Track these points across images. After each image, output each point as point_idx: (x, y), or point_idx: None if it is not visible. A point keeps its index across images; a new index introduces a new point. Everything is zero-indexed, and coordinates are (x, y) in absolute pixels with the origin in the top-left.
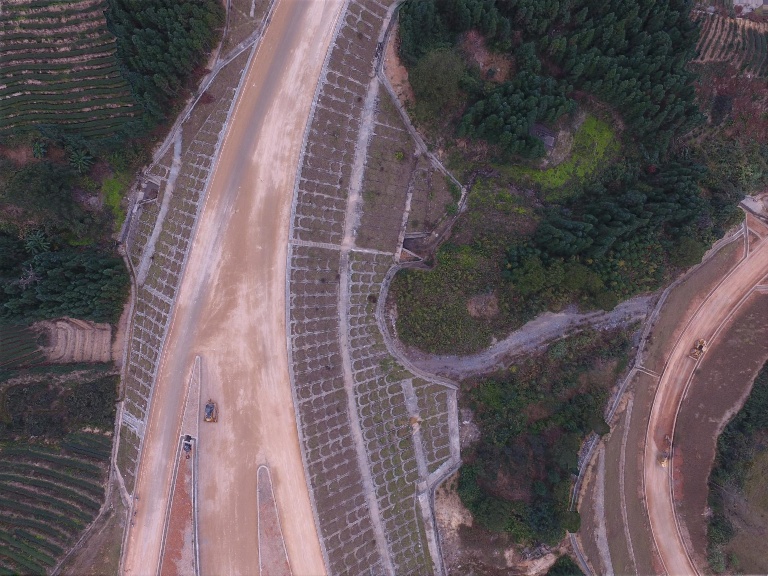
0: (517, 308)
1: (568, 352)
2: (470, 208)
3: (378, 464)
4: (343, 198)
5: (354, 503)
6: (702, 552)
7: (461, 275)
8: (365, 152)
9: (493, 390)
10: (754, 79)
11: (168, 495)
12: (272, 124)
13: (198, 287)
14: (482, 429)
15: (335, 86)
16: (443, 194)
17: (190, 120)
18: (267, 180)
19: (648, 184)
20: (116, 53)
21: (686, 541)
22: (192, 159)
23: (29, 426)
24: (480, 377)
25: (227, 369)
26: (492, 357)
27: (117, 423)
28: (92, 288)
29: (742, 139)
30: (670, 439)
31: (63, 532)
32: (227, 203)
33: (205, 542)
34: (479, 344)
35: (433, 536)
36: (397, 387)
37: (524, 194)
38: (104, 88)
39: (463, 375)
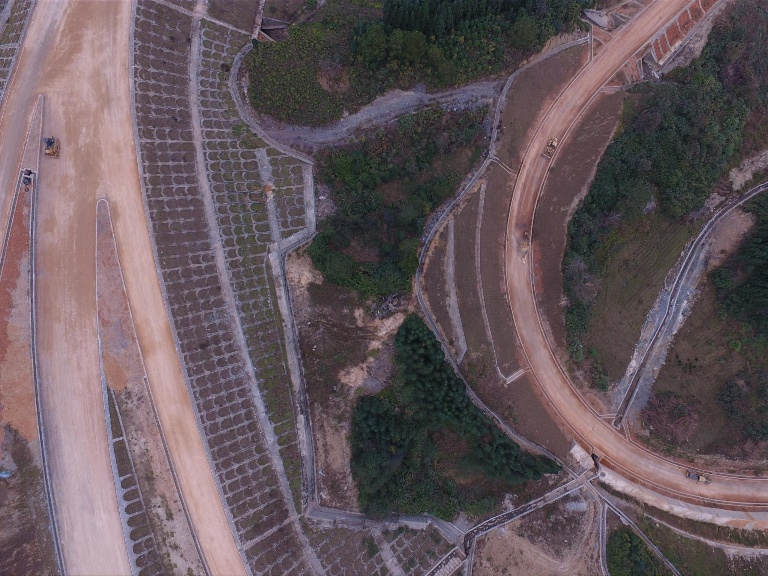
0: (365, 81)
1: (417, 127)
2: None
3: (226, 217)
4: None
5: (198, 247)
6: (563, 344)
7: (309, 43)
8: None
9: (345, 161)
10: None
11: (6, 227)
12: None
13: (44, 32)
14: (338, 204)
15: None
16: None
17: None
18: None
19: None
20: None
21: (548, 336)
22: None
23: None
24: (333, 149)
25: (70, 108)
26: (344, 130)
27: None
28: None
29: None
30: (529, 236)
31: None
32: None
33: (42, 273)
34: (329, 114)
35: (283, 293)
36: (251, 155)
37: None
38: None
39: (316, 146)
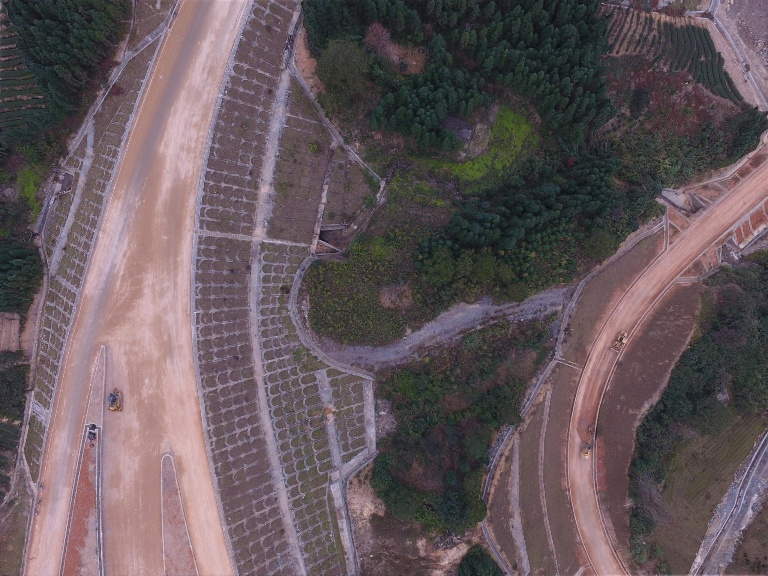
0: (430, 299)
1: (482, 343)
2: (389, 200)
3: (288, 454)
4: (254, 189)
5: (262, 492)
6: (625, 543)
7: (372, 266)
8: (276, 144)
9: (407, 381)
10: (671, 73)
11: (73, 483)
12: (179, 115)
13: (104, 277)
14: (398, 420)
15: (243, 78)
16: (361, 186)
17: (101, 112)
18: (173, 171)
19: (563, 177)
20: (18, 44)
21: (610, 532)
22: (103, 150)
23: None
24: (395, 368)
25: (132, 358)
26: (406, 348)
27: (27, 412)
28: None
29: (662, 133)
30: (593, 431)
31: None
32: (133, 194)
33: (109, 530)
34: (392, 335)
35: (345, 526)
36: (311, 377)
37: (443, 187)
38: (13, 80)
39: (377, 366)
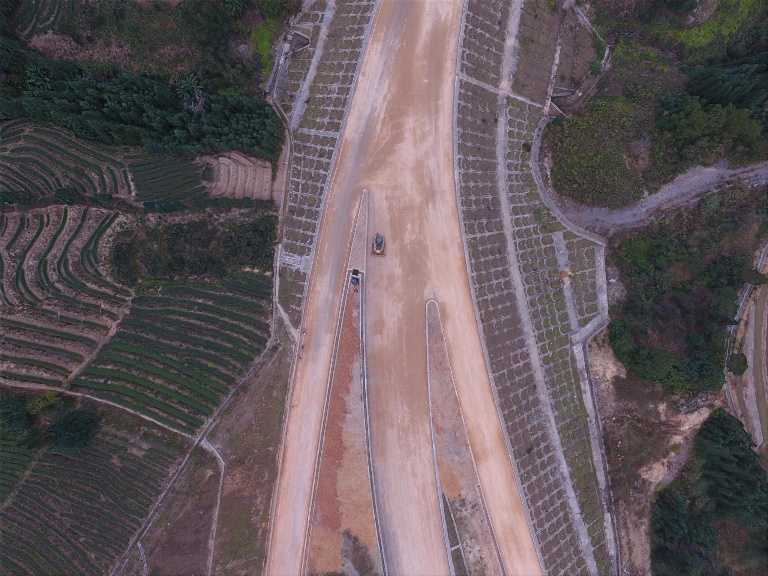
0: (671, 159)
1: (719, 206)
2: (614, 67)
3: (536, 310)
4: (501, 41)
5: (516, 345)
6: None
7: (618, 121)
8: None
9: (644, 244)
10: None
11: (335, 330)
12: None
13: (364, 120)
14: (629, 287)
15: None
16: (589, 50)
17: None
18: (433, 13)
19: None
20: None
21: None
22: None
23: (190, 264)
24: (631, 231)
25: (394, 203)
26: (643, 211)
27: (275, 265)
28: (257, 121)
29: None
30: None
31: (233, 362)
32: (393, 36)
33: (373, 377)
34: (632, 195)
35: (588, 387)
36: (549, 239)
37: None
38: None
39: (614, 228)
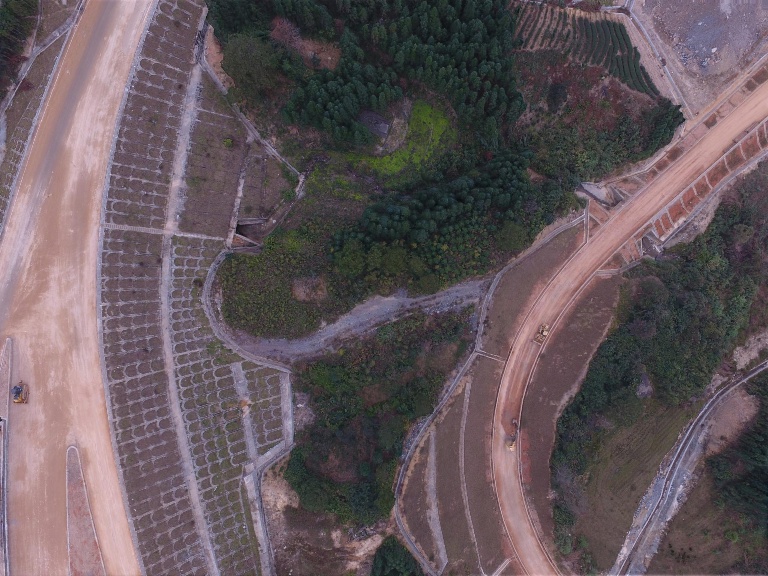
0: (343, 292)
1: (397, 335)
2: (307, 194)
3: (200, 446)
4: (165, 183)
5: (171, 484)
6: (550, 535)
7: (284, 259)
8: (188, 138)
9: (323, 373)
10: (587, 67)
11: None
12: (85, 110)
13: (10, 270)
14: (316, 412)
15: (150, 73)
16: (278, 181)
17: (13, 107)
18: (80, 165)
19: (479, 170)
20: None
21: (536, 524)
22: (13, 145)
23: None
24: (310, 360)
25: (38, 351)
26: (322, 340)
27: None
28: None
29: (581, 127)
30: (517, 423)
31: None
32: (40, 187)
33: (15, 522)
34: (306, 327)
35: (259, 517)
36: (226, 370)
37: (363, 181)
38: None
39: (293, 358)
